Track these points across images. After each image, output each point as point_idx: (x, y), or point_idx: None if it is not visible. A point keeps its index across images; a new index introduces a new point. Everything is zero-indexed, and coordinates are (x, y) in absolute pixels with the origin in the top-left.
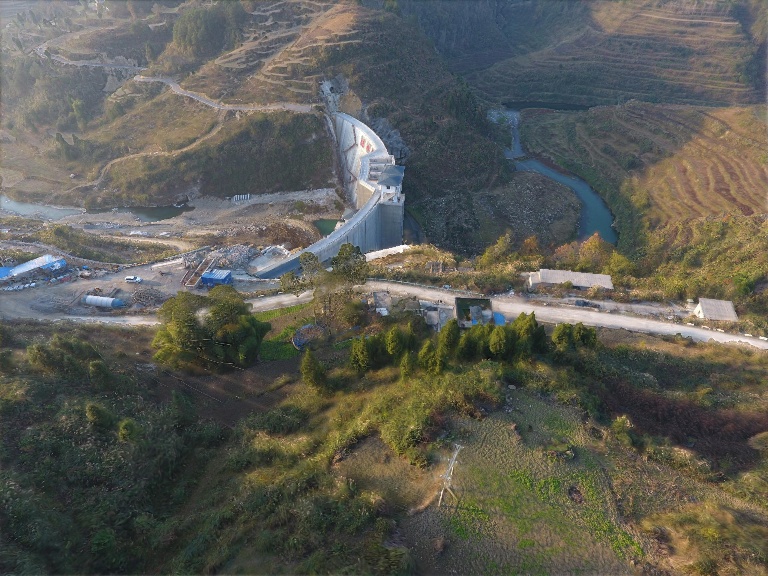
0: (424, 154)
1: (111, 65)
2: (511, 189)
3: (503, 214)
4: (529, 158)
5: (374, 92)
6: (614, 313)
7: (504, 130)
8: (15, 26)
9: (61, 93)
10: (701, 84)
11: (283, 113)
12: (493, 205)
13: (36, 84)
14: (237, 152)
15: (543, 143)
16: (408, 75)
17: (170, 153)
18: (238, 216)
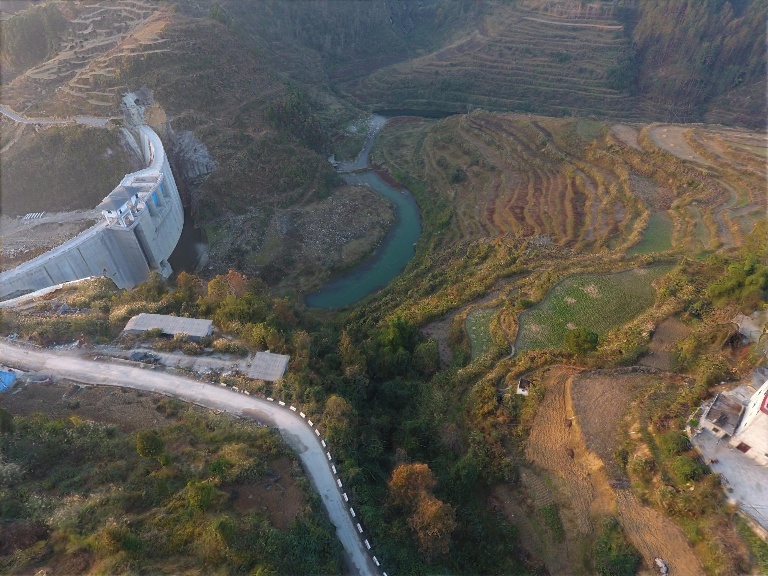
0: (229, 169)
1: None
2: (325, 205)
3: (299, 233)
4: (367, 170)
5: (181, 104)
6: (158, 370)
7: (357, 140)
8: None
9: None
10: (575, 91)
11: (75, 127)
12: (294, 223)
13: None
14: (27, 168)
15: (387, 154)
16: (224, 86)
17: None
18: (23, 236)
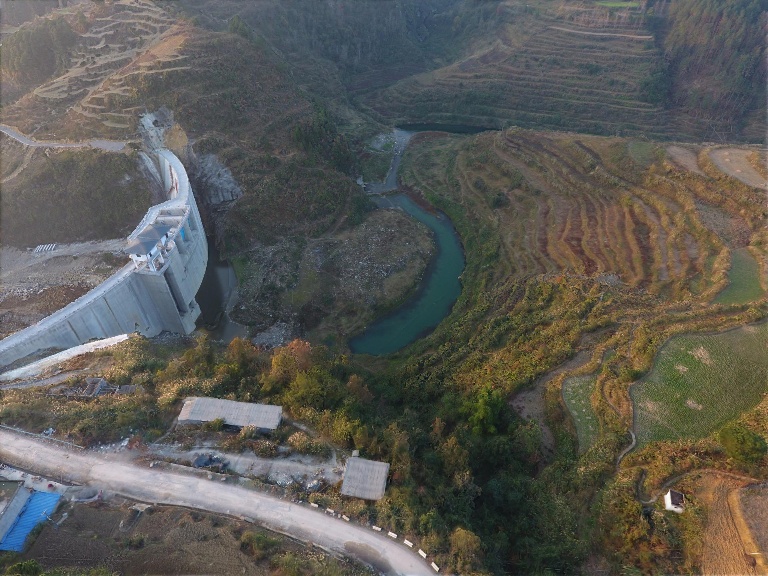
0: (257, 196)
1: None
2: (358, 233)
3: (335, 266)
4: (398, 192)
5: (203, 125)
6: (230, 482)
7: (383, 158)
8: None
9: None
10: (607, 104)
11: (90, 152)
12: (328, 254)
13: None
14: (38, 197)
15: (418, 174)
16: (248, 105)
17: None
18: (34, 271)
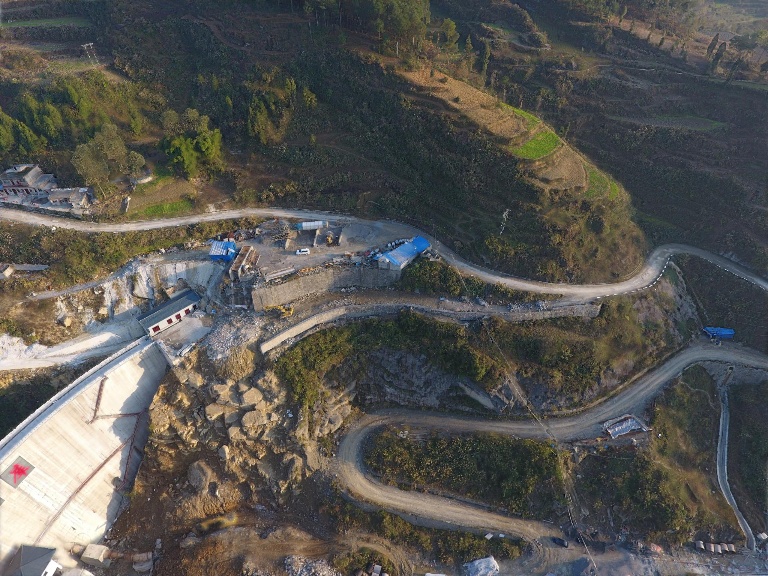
0: None
1: None
2: None
3: None
4: None
5: None
6: None
7: None
8: None
9: None
10: None
11: None
12: None
13: None
14: None
15: None
16: None
17: None
18: None
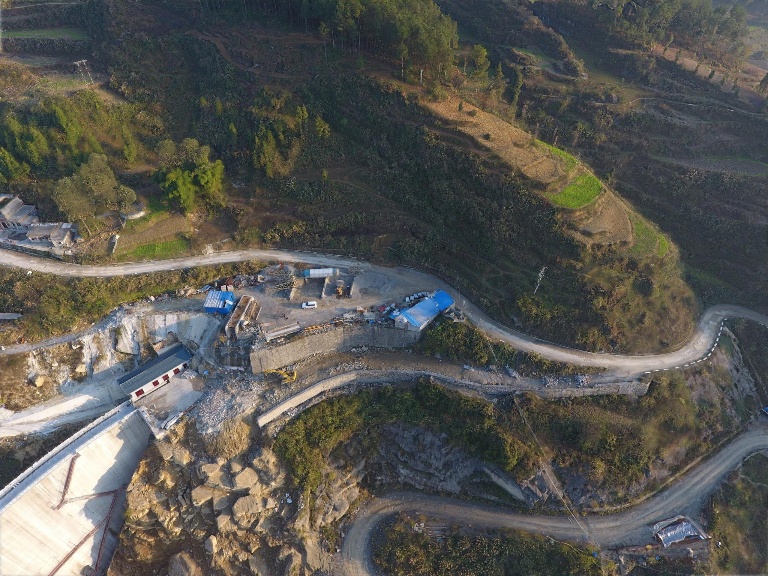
0: None
1: None
2: None
3: None
4: None
5: None
6: None
7: None
8: None
9: None
10: None
11: None
12: None
13: None
14: None
15: None
16: None
17: None
18: None
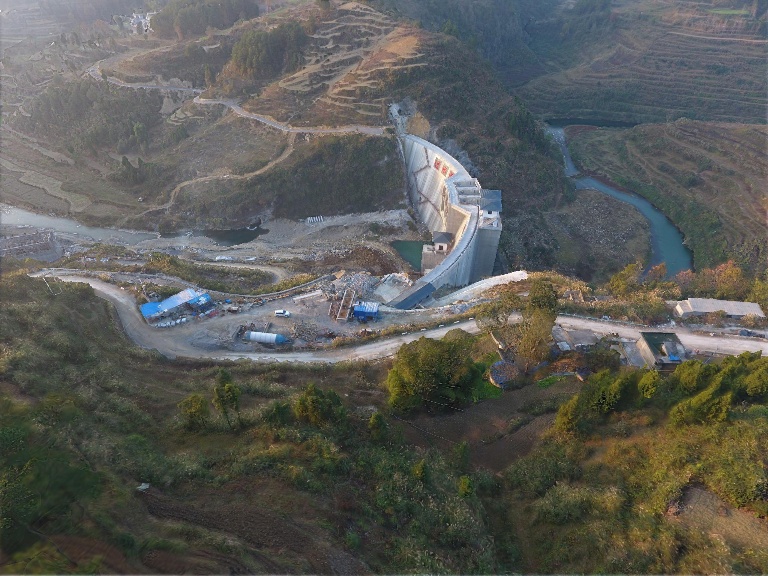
0: (493, 175)
1: (166, 87)
2: (578, 208)
3: (577, 233)
4: (585, 176)
5: (441, 114)
6: None
7: (554, 148)
8: (56, 47)
9: (120, 116)
10: (738, 101)
11: (356, 136)
12: (565, 224)
13: (95, 107)
14: (310, 175)
15: (596, 161)
16: (472, 97)
17: (243, 176)
18: (314, 238)
